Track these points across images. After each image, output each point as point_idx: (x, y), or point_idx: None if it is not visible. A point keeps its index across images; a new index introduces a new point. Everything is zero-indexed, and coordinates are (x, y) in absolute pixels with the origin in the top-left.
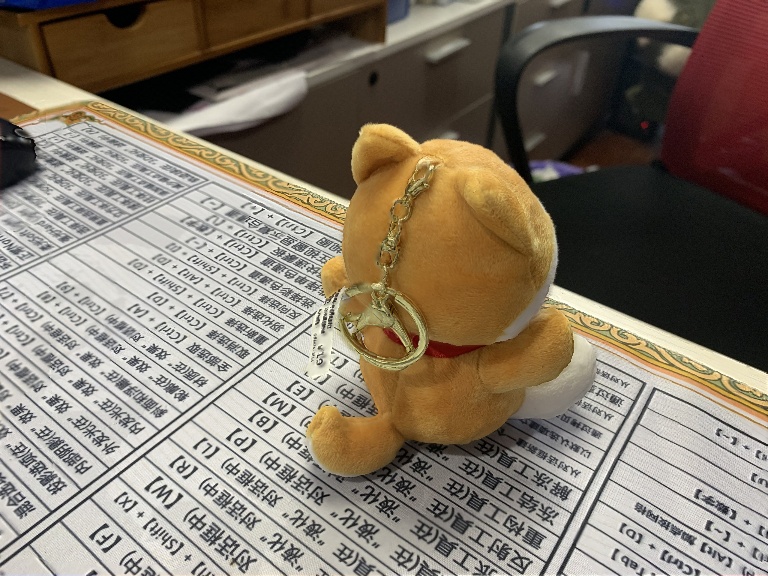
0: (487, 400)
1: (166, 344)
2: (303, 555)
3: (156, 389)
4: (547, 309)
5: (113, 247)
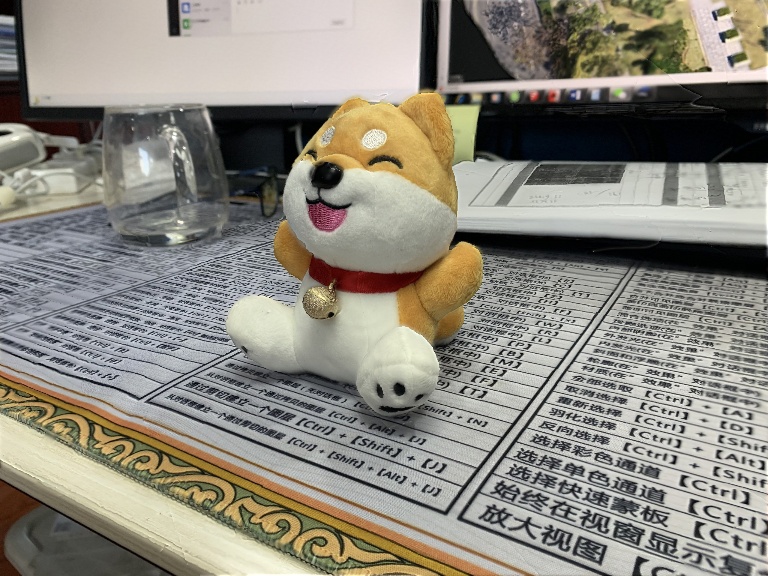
0: None
1: (657, 388)
2: None
3: None
4: None
5: None
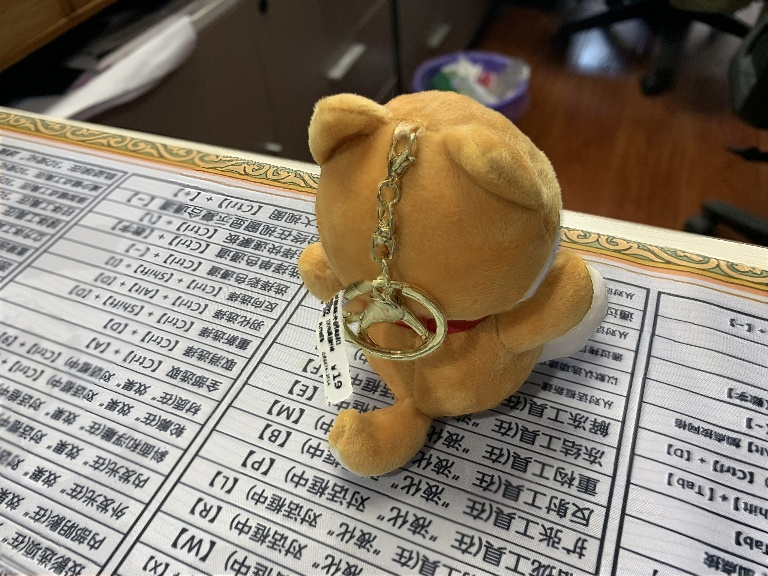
0: (512, 362)
1: (142, 376)
2: (362, 571)
3: (147, 430)
4: (558, 254)
5: (45, 278)
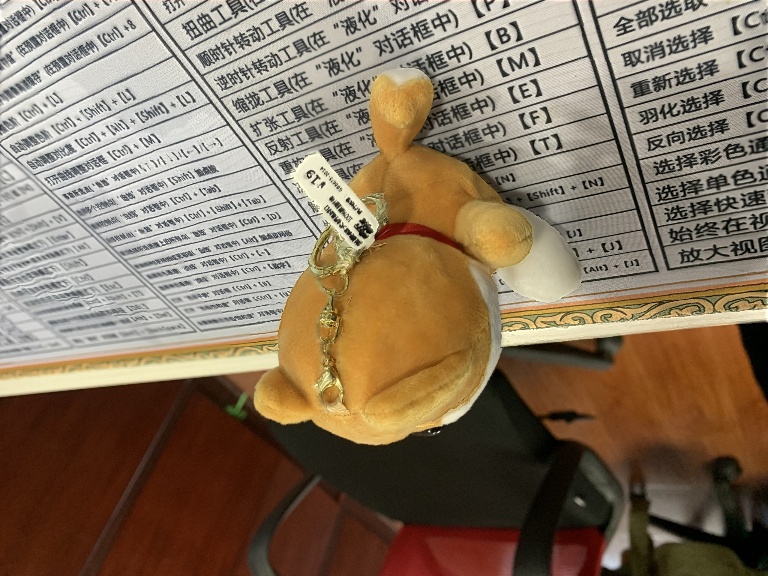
0: None
1: None
2: (330, 6)
3: None
4: None
5: None
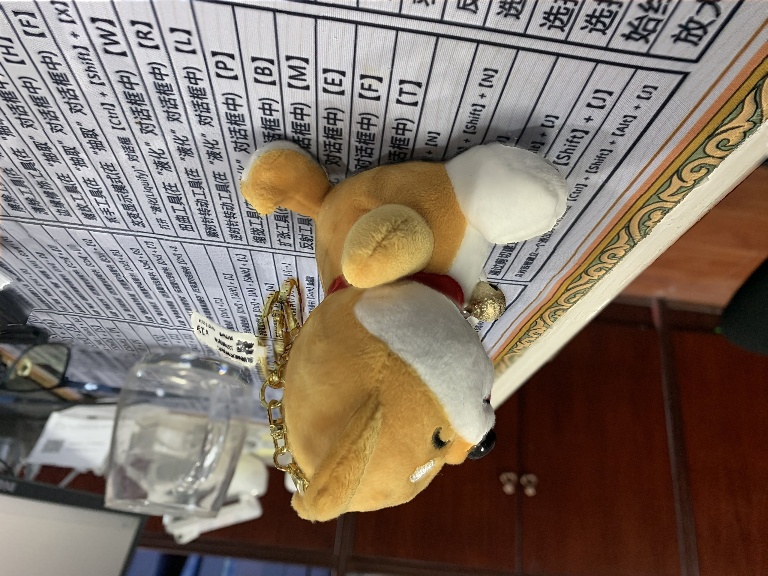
0: None
1: None
2: None
3: None
4: None
5: None
